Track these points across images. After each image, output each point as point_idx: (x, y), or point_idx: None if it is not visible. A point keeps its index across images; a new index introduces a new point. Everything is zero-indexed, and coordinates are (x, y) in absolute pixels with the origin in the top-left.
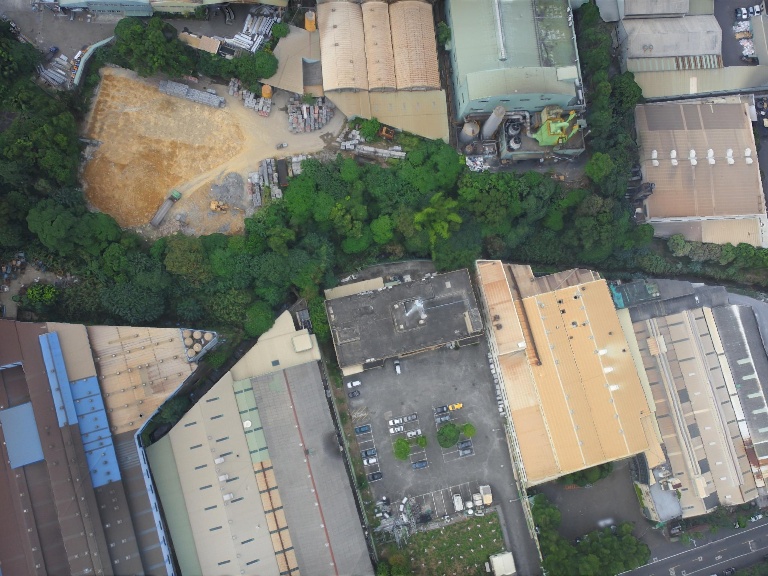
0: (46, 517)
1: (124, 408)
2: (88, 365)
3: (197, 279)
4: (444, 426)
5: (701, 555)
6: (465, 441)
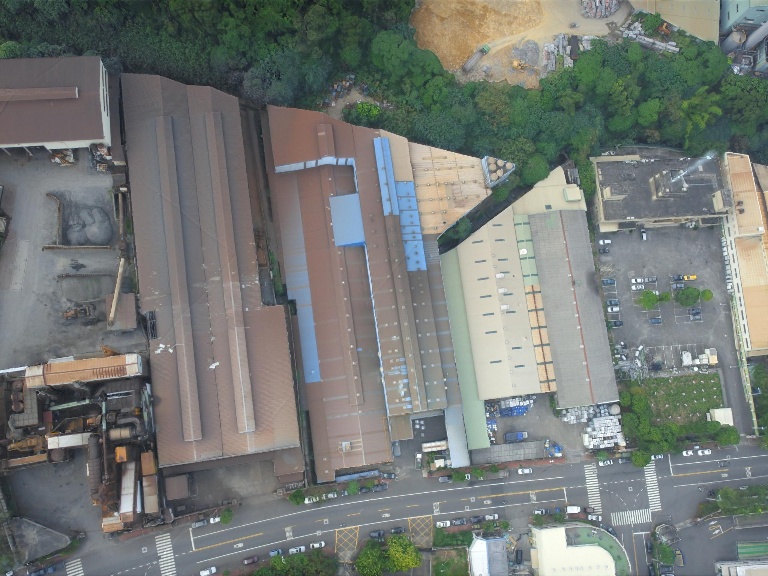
0: (357, 293)
1: (431, 214)
2: (408, 171)
3: (497, 121)
4: (685, 288)
5: None
6: (696, 308)
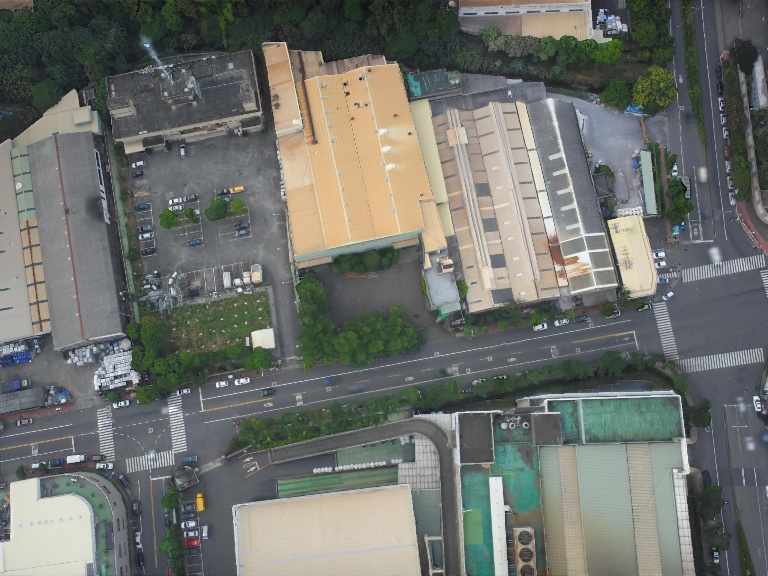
0: None
1: None
2: None
3: None
4: None
5: (491, 355)
6: (243, 223)
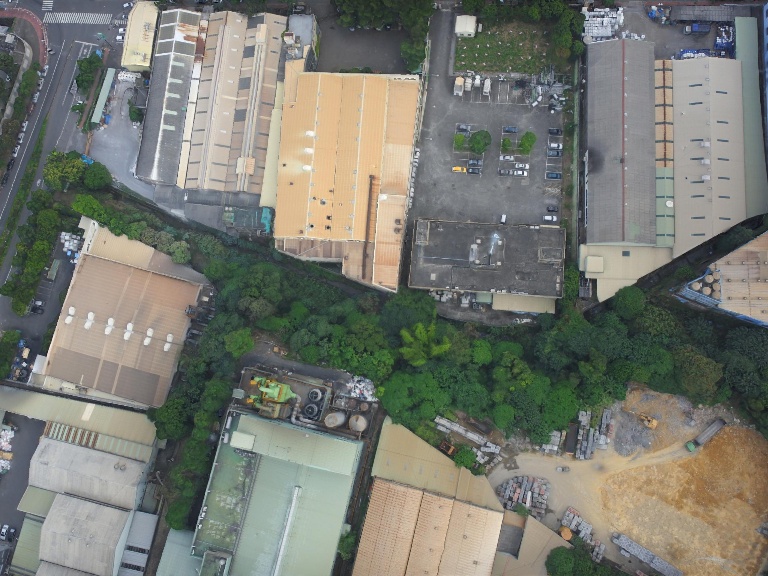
0: None
1: None
2: None
3: None
4: None
5: None
6: None
